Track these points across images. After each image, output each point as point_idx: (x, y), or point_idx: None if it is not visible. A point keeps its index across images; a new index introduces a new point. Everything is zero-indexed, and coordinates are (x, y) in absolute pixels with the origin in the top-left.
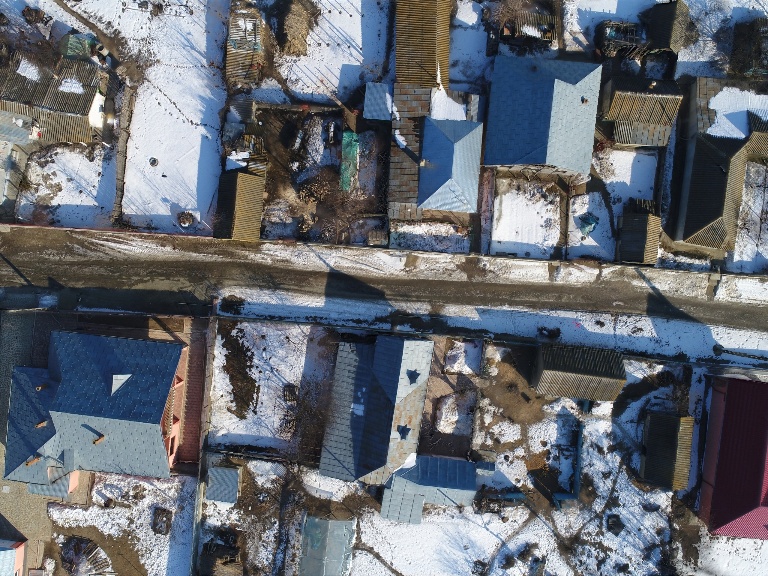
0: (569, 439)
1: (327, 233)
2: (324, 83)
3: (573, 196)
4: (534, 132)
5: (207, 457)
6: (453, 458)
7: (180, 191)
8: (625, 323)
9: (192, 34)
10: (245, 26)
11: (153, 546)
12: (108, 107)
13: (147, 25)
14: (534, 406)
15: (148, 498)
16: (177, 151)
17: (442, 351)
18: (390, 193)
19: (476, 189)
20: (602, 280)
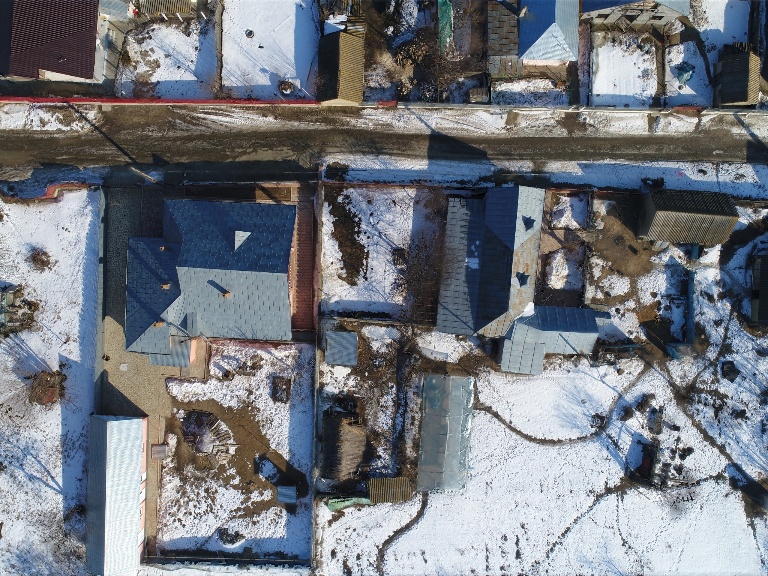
0: (678, 289)
1: (427, 94)
2: None
3: (668, 46)
4: None
5: (321, 324)
6: (569, 307)
7: (278, 61)
8: (727, 171)
9: None
10: None
11: (273, 416)
12: None
13: None
14: (642, 258)
15: (266, 368)
16: (272, 21)
17: (548, 207)
18: (490, 47)
19: (577, 37)
20: (701, 129)
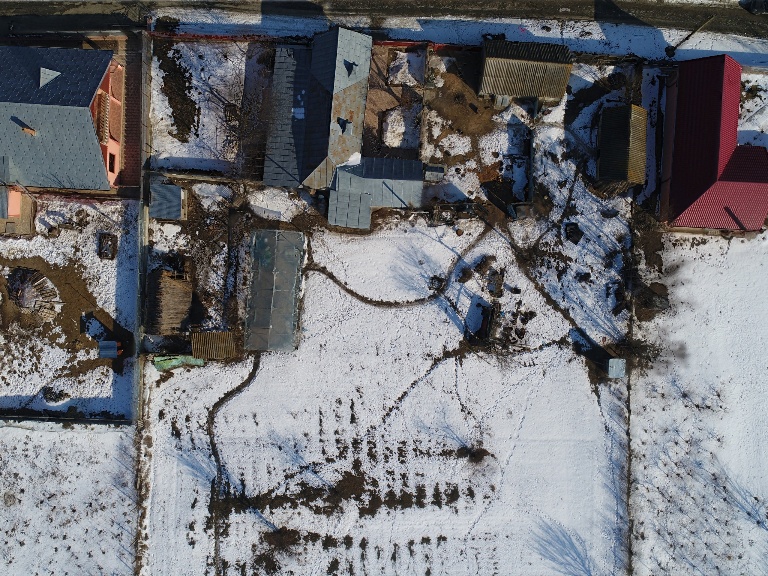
0: (521, 149)
1: None
2: None
3: None
4: None
5: (150, 181)
6: None
7: None
8: (572, 28)
9: None
10: None
11: (100, 273)
12: None
13: None
14: (483, 117)
15: (92, 224)
16: None
17: (385, 63)
18: None
19: None
20: None
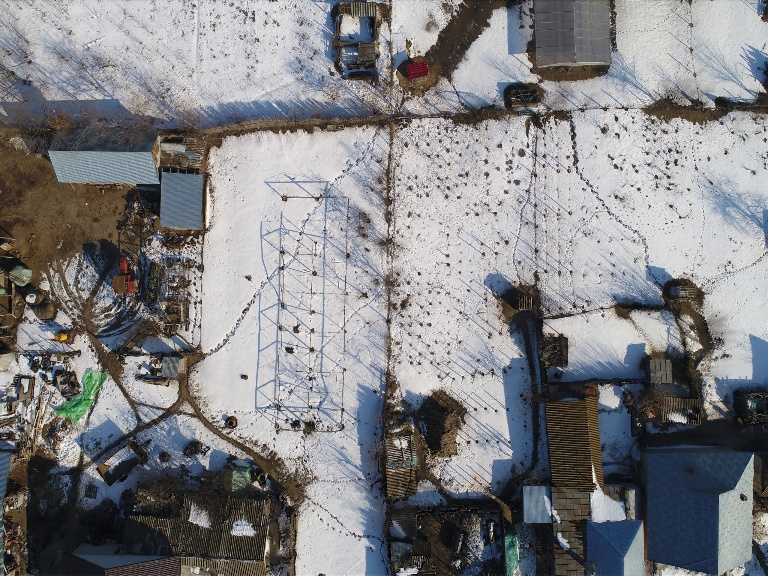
0: None
1: None
2: (477, 480)
3: None
4: (701, 542)
5: None
6: None
7: None
8: None
9: (346, 448)
10: (401, 445)
11: None
12: (273, 529)
13: (301, 444)
14: None
15: None
16: (343, 564)
17: None
18: None
19: None
20: None
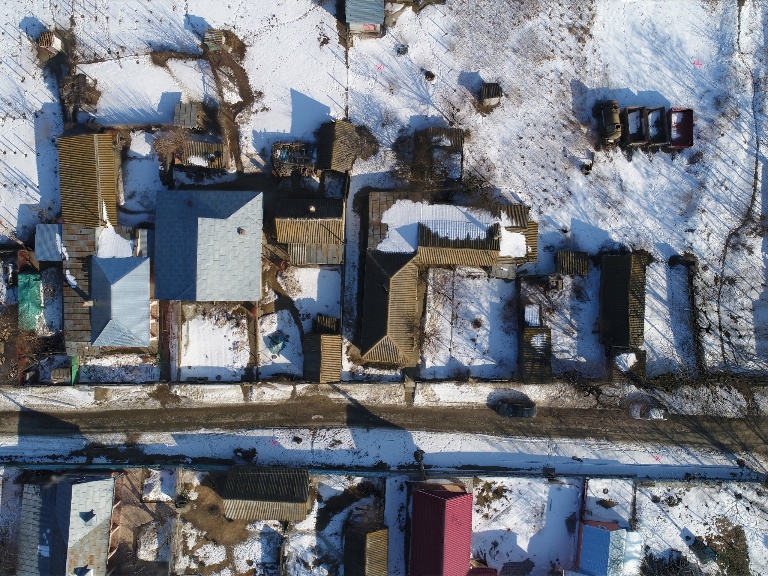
0: (275, 556)
1: (12, 374)
2: (3, 224)
3: (262, 316)
4: (187, 269)
5: None
6: None
7: None
8: (324, 437)
9: None
10: None
11: None
12: None
13: None
14: (237, 526)
15: None
16: None
17: (138, 480)
18: (66, 332)
19: (147, 324)
20: (298, 396)
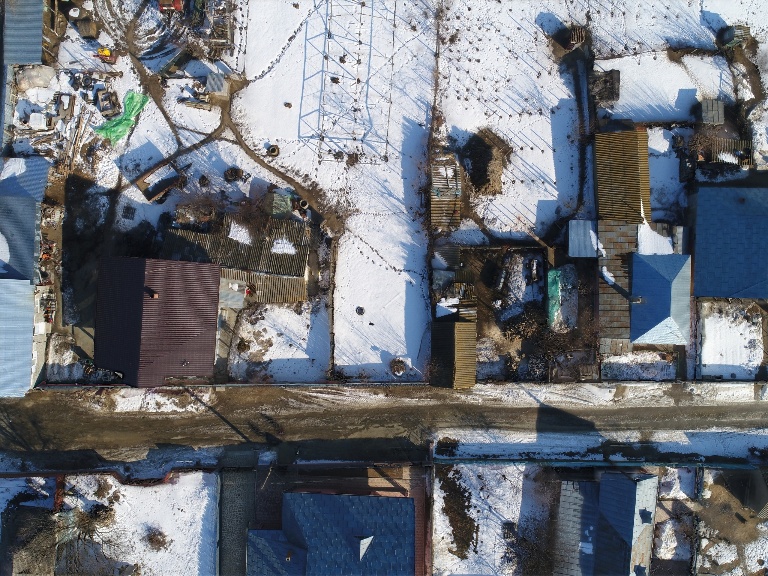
0: None
1: (537, 371)
2: (521, 220)
3: None
4: (752, 267)
5: None
6: None
7: (388, 338)
8: None
9: (389, 181)
10: (446, 173)
11: None
12: (312, 260)
13: (344, 175)
14: (748, 525)
15: None
16: (382, 298)
17: None
18: (601, 329)
19: (688, 321)
20: None
